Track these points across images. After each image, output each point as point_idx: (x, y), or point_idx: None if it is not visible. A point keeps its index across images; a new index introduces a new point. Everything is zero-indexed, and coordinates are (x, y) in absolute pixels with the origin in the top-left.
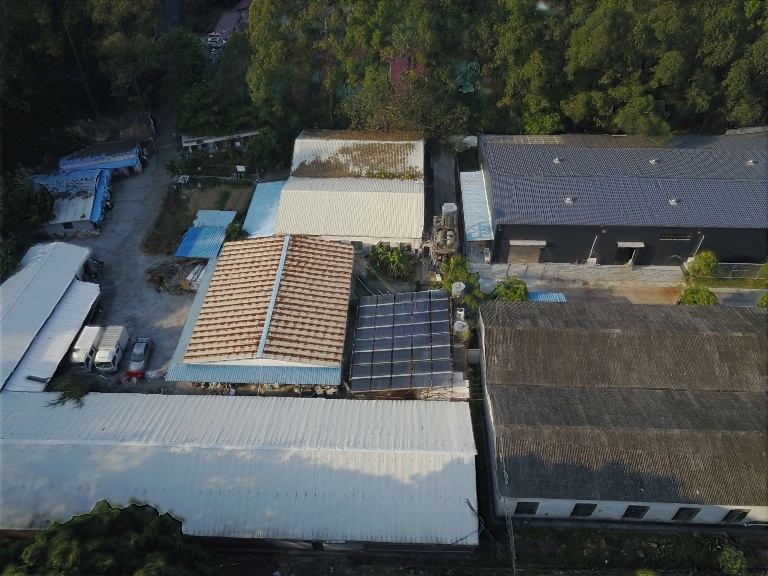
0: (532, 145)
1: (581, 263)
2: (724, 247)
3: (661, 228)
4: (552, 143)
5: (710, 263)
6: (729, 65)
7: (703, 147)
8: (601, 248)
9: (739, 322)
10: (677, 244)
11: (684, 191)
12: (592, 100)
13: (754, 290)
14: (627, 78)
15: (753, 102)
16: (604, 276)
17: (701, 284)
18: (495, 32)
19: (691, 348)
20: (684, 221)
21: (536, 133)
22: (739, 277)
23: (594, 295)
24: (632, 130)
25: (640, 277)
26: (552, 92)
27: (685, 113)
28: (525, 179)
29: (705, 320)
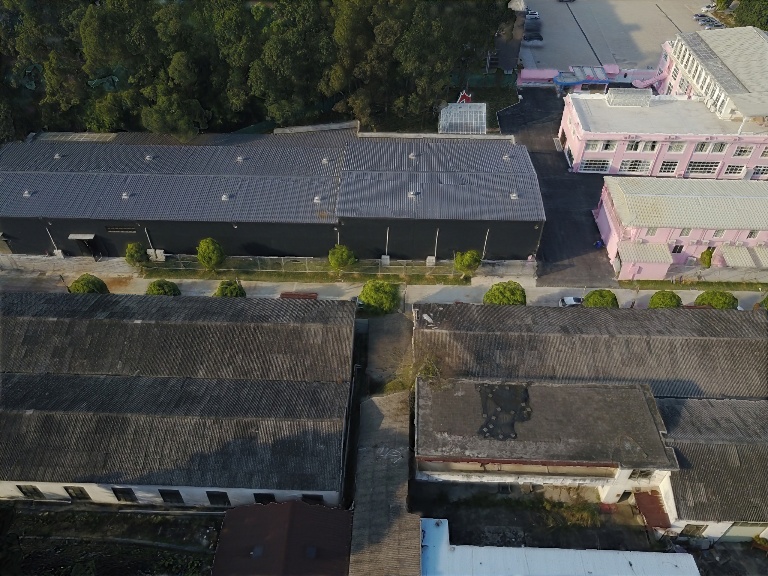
0: (77, 142)
1: (53, 255)
2: (174, 239)
3: (97, 220)
4: (102, 140)
5: (133, 254)
6: (248, 66)
7: (238, 145)
8: (61, 240)
9: (77, 308)
10: (128, 236)
11: (145, 186)
12: (122, 99)
13: (197, 280)
14: (158, 78)
15: (294, 102)
16: (66, 267)
17: (151, 275)
18: (16, 32)
19: (1, 332)
20: (120, 214)
21: (98, 131)
22: (191, 268)
23: (39, 285)
24: (151, 128)
25: (100, 268)
26: (114, 91)
27: (232, 112)
28: (5, 173)
29: (47, 306)
